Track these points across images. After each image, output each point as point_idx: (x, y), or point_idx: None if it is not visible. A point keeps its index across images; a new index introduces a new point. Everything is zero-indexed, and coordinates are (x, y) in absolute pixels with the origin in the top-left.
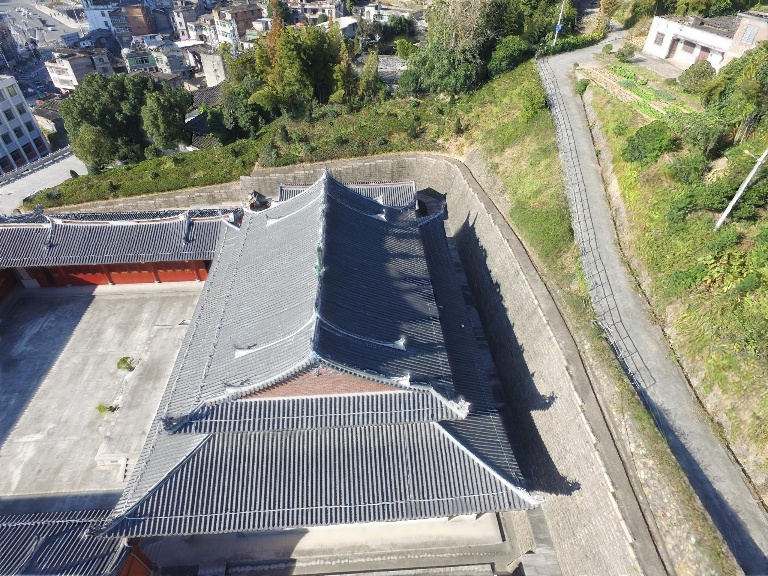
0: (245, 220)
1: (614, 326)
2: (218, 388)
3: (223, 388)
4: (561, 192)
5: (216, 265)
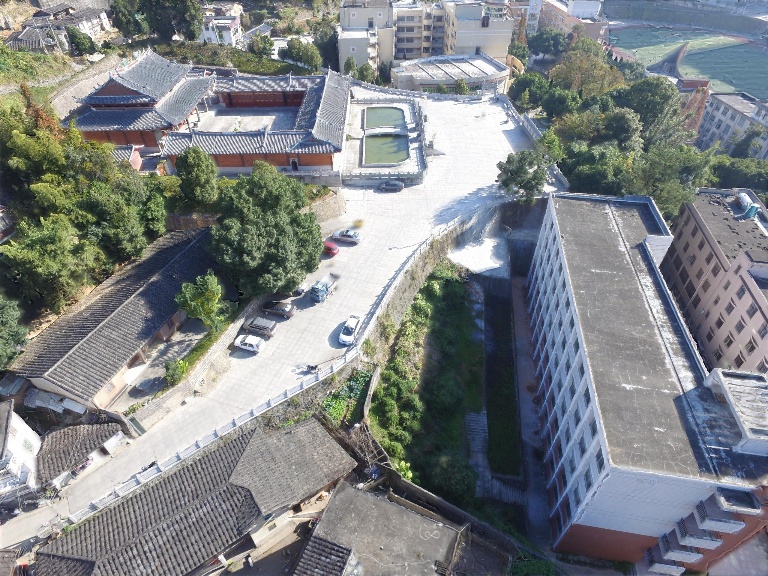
0: (158, 98)
1: (59, 81)
2: (179, 66)
3: (177, 65)
4: (7, 94)
5: (182, 114)
